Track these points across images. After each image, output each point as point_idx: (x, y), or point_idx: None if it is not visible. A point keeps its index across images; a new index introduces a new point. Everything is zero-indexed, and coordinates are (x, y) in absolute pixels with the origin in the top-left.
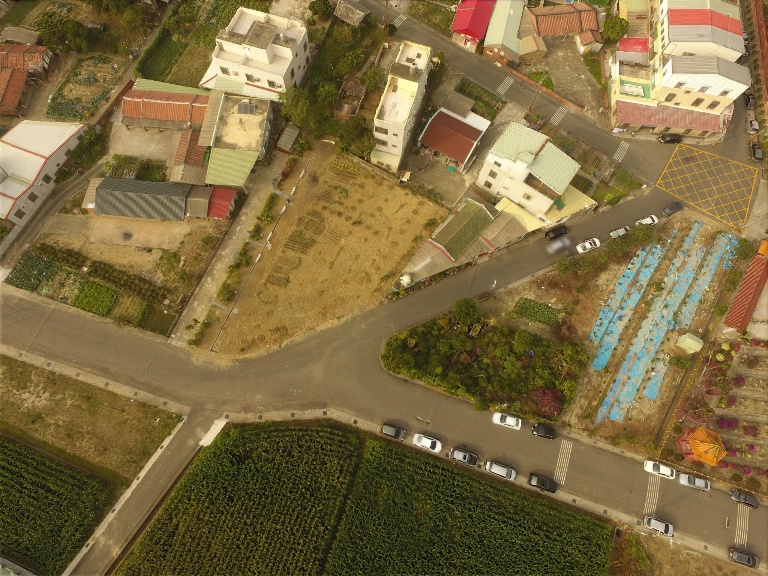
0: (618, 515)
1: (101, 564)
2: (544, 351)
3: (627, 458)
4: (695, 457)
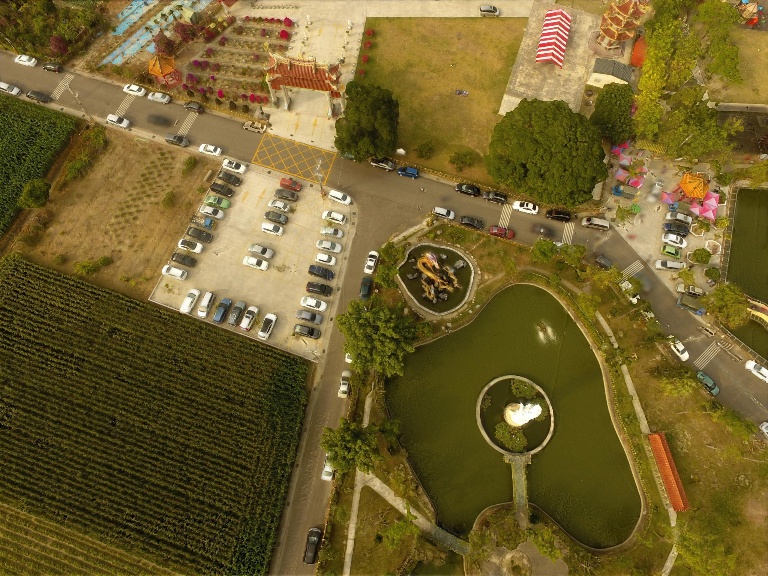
0: (93, 118)
1: None
2: (65, 15)
3: (114, 85)
4: (149, 71)
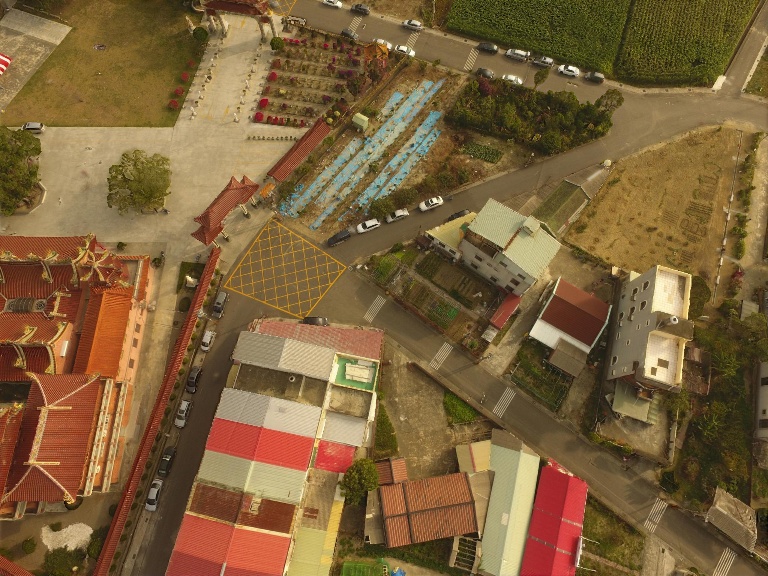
0: (437, 33)
1: (759, 24)
2: None
3: (425, 60)
4: None
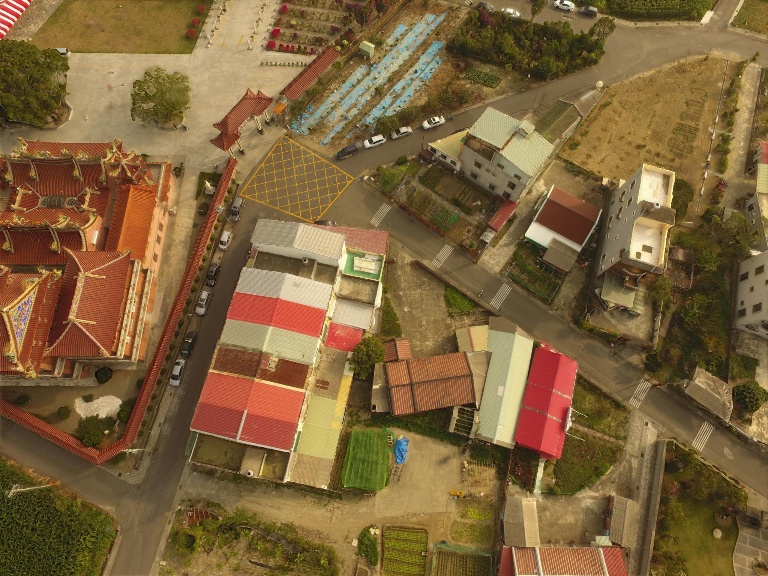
0: None
1: None
2: None
3: None
4: None
